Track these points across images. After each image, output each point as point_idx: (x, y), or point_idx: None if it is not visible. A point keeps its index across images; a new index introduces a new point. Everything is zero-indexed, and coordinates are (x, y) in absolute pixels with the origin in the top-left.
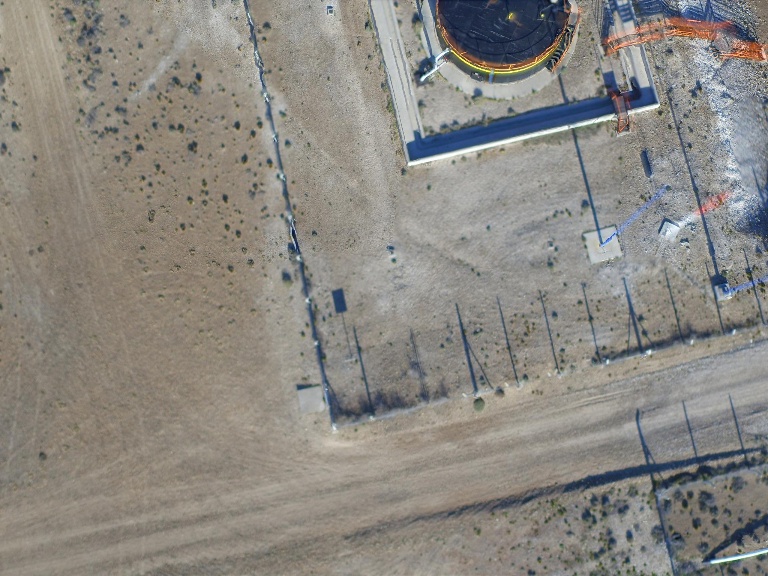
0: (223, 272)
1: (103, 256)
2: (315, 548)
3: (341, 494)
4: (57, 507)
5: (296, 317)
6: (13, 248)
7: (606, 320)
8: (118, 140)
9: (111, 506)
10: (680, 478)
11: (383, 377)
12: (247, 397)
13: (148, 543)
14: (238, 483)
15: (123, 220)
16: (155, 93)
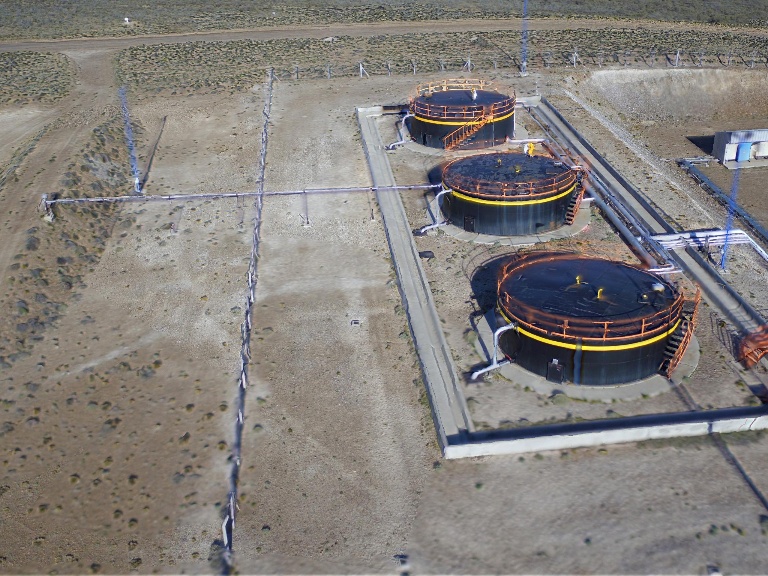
0: (78, 572)
1: None
2: None
3: None
4: None
5: None
6: None
7: None
8: (7, 411)
9: None
10: None
11: None
12: None
13: None
14: None
15: None
16: (89, 373)
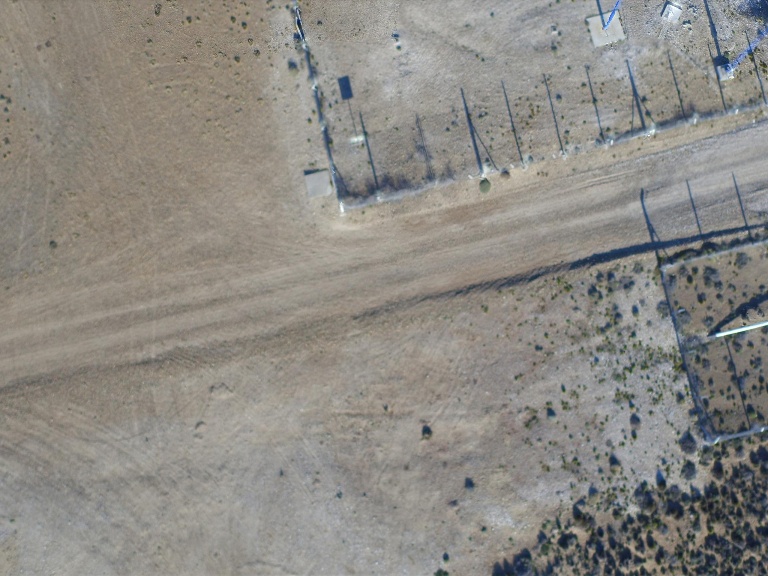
0: (229, 63)
1: (110, 50)
2: (324, 328)
3: (349, 276)
4: (68, 293)
5: (302, 105)
6: (21, 44)
7: (610, 102)
8: None
9: (122, 292)
10: (685, 254)
11: (389, 161)
12: (255, 184)
13: (159, 327)
14: (247, 267)
15: (130, 14)
16: None
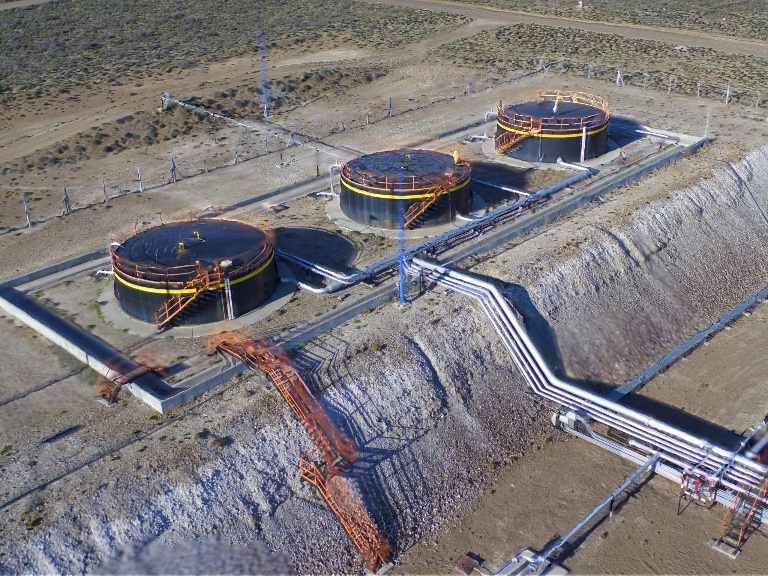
0: None
1: None
2: None
3: None
4: None
5: None
6: None
7: None
8: None
9: None
10: None
11: None
12: None
13: None
14: None
15: None
16: (13, 190)
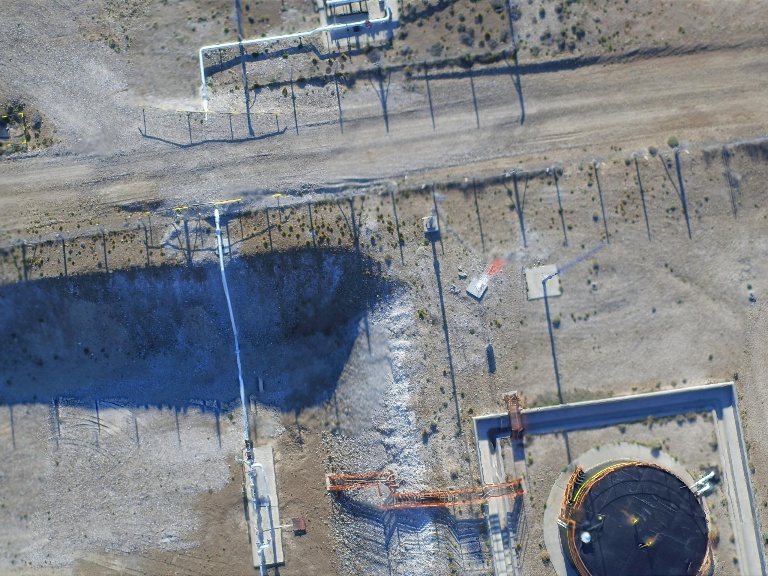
0: None
1: None
2: None
3: None
4: None
5: None
6: None
7: (546, 209)
8: None
9: None
10: (491, 59)
11: (765, 176)
12: None
13: None
14: None
15: None
16: None
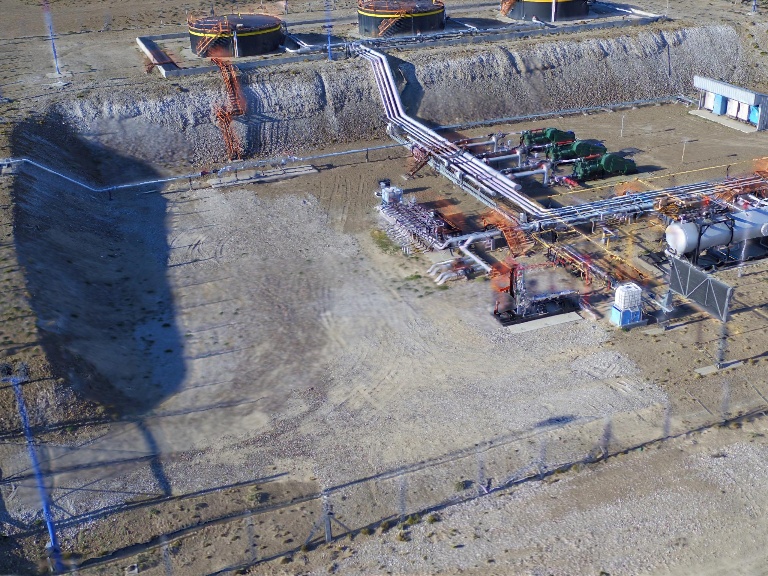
0: None
1: None
2: None
3: None
4: None
5: None
6: None
7: (1, 81)
8: None
9: None
10: None
11: None
12: (3, 35)
13: None
14: None
15: None
16: None
